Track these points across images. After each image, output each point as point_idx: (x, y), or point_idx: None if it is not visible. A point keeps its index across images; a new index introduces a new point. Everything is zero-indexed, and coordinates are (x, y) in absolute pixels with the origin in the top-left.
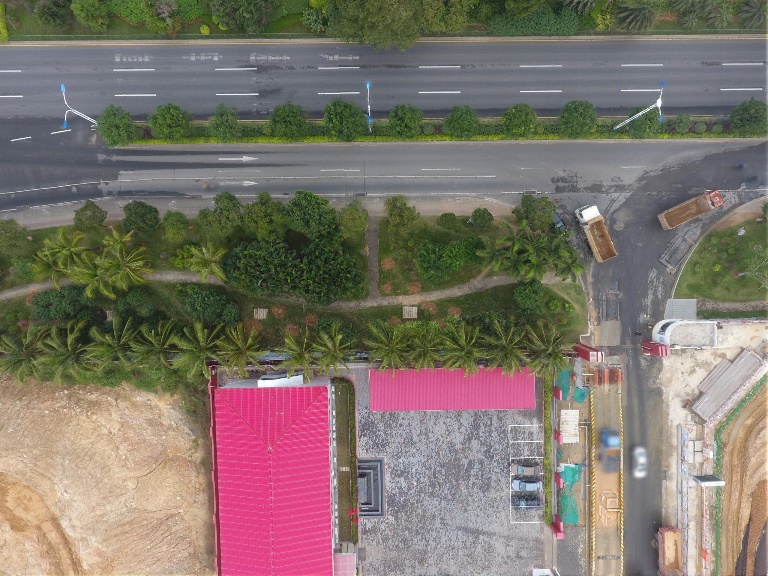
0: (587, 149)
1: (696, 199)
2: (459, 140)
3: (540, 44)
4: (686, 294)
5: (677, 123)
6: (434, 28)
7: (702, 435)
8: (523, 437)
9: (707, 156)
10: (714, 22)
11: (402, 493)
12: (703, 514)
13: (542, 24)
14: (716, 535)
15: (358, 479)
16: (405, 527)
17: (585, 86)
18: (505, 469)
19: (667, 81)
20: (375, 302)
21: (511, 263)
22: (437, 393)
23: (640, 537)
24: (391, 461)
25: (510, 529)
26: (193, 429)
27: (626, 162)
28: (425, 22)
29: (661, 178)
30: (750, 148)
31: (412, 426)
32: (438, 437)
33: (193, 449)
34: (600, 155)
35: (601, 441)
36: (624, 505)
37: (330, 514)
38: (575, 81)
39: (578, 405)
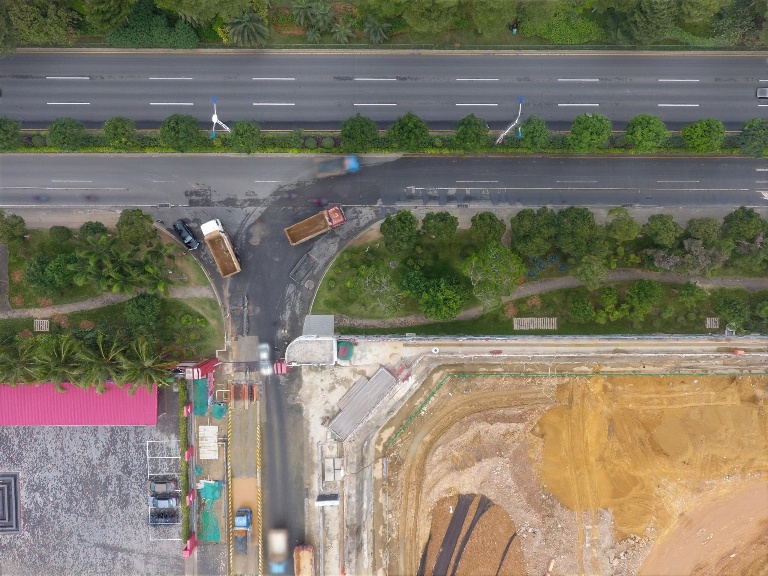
0: (221, 163)
1: (322, 215)
2: (88, 152)
3: (169, 56)
4: (323, 310)
5: (290, 138)
6: (33, 39)
7: (343, 453)
8: (161, 453)
9: (342, 171)
10: (336, 37)
11: (38, 509)
12: None
13: (156, 37)
14: None
15: None
16: (42, 543)
17: (216, 99)
18: (143, 485)
19: (299, 95)
20: (6, 315)
21: (96, 278)
22: (57, 408)
23: (283, 555)
24: (26, 476)
25: (149, 546)
26: None
27: (260, 176)
28: (23, 33)
29: (296, 193)
30: (386, 164)
31: (47, 441)
32: (74, 452)
33: None
34: (234, 169)
35: (237, 458)
36: (266, 523)
37: None
38: (206, 94)
39: (217, 421)
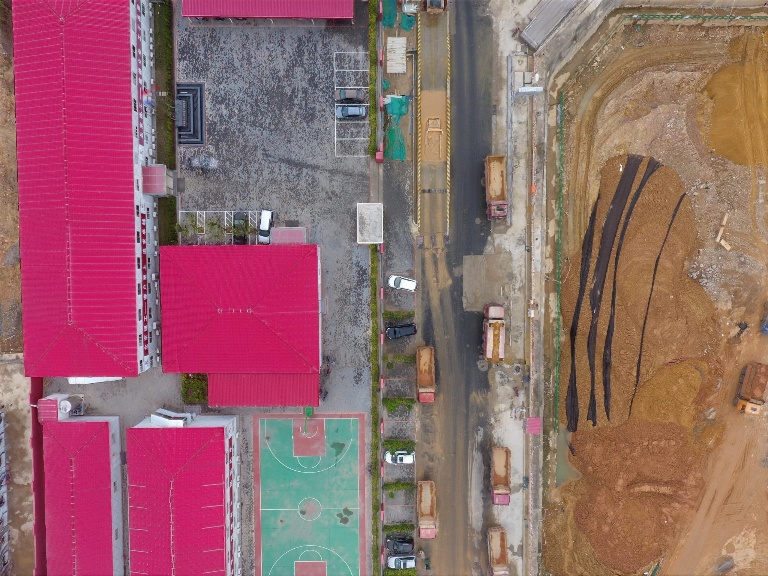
0: None
1: None
2: None
3: None
4: None
5: None
6: None
7: (532, 67)
8: (348, 65)
9: None
10: None
11: (223, 121)
12: (533, 149)
13: None
14: (559, 202)
15: (175, 101)
16: (226, 157)
17: None
18: (330, 99)
19: None
20: None
21: None
22: None
23: (469, 175)
24: (212, 87)
25: (335, 163)
26: (5, 44)
27: None
28: None
29: None
30: None
31: (234, 50)
32: (261, 63)
33: (5, 66)
34: None
35: (427, 67)
36: (452, 140)
37: (131, 105)
38: None
39: (405, 33)
